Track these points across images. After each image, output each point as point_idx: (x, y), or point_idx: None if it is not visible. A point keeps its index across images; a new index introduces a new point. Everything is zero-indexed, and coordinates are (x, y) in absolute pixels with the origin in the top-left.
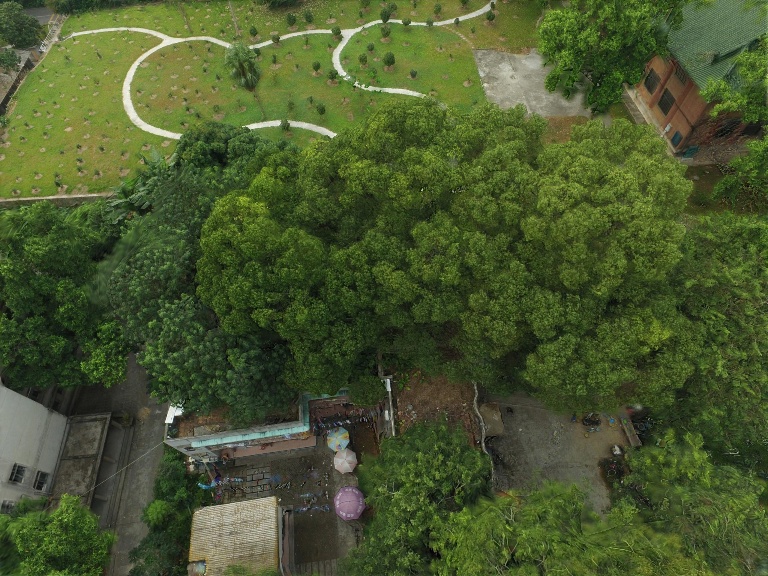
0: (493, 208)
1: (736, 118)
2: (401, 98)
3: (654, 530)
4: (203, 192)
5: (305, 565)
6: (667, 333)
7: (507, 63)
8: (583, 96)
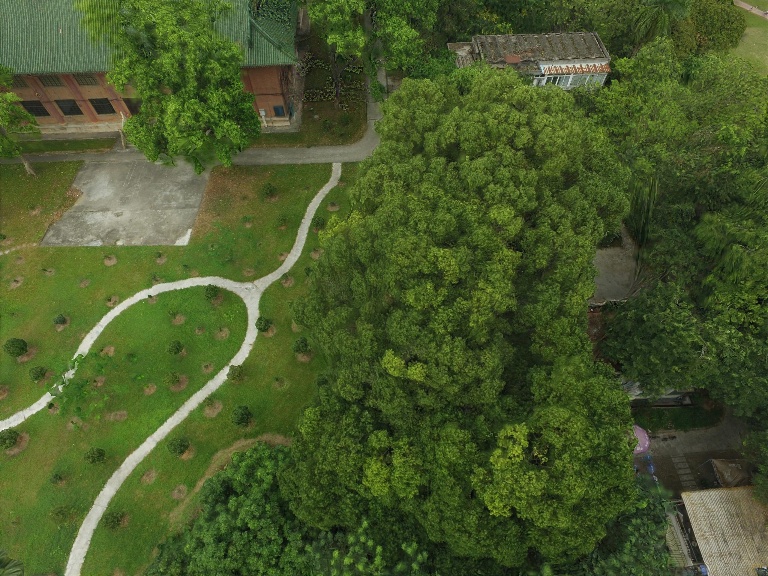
0: (532, 188)
1: (283, 67)
2: (104, 342)
3: (678, 196)
4: (402, 575)
5: (685, 488)
6: (600, 129)
7: (88, 215)
8: (180, 162)
